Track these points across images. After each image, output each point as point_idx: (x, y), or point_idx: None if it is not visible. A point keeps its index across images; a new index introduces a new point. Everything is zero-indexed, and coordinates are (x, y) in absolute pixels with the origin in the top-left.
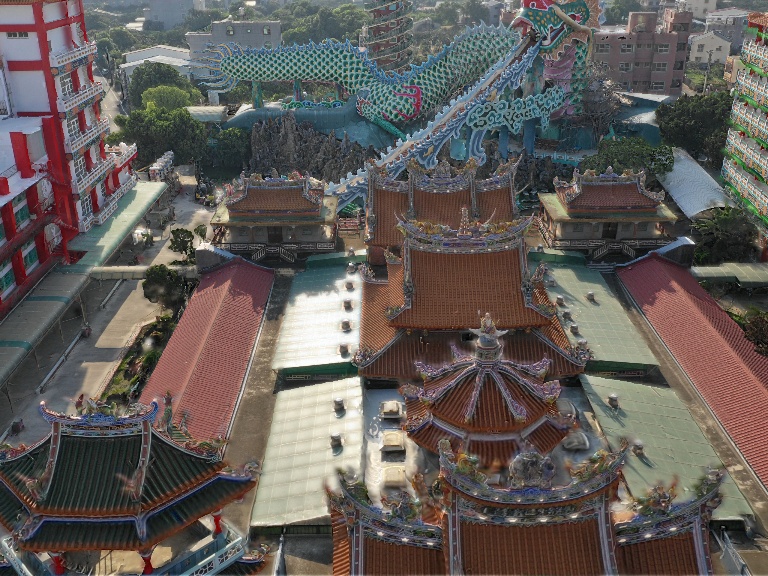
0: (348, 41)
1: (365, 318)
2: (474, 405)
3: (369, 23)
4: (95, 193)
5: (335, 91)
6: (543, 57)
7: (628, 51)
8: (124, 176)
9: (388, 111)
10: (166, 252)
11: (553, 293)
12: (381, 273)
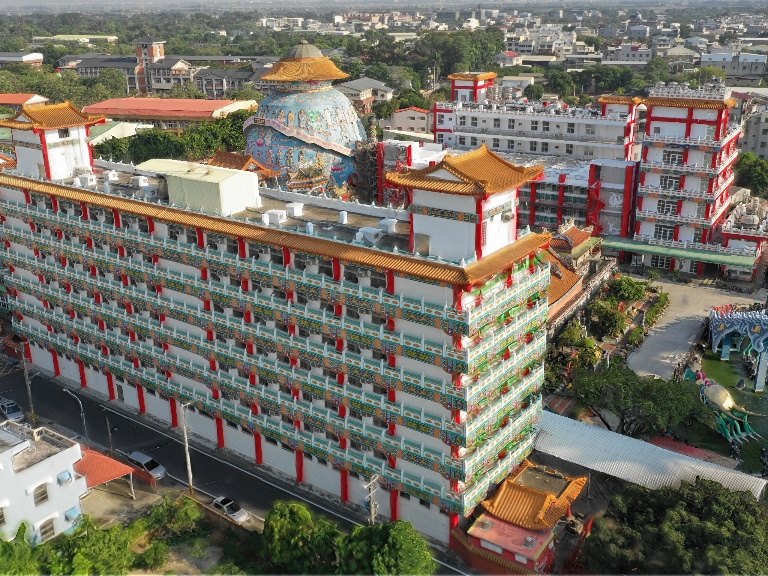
0: None
1: None
2: None
3: None
4: (676, 231)
5: None
6: None
7: None
8: (741, 245)
9: None
10: (661, 283)
11: None
12: None
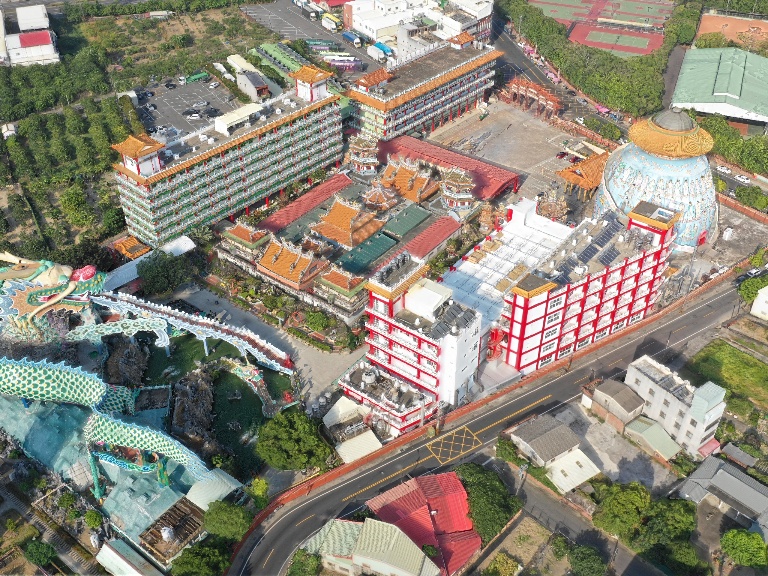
0: None
1: None
2: (388, 191)
3: None
4: None
5: None
6: None
7: None
8: None
9: None
10: None
11: (306, 230)
12: (332, 262)
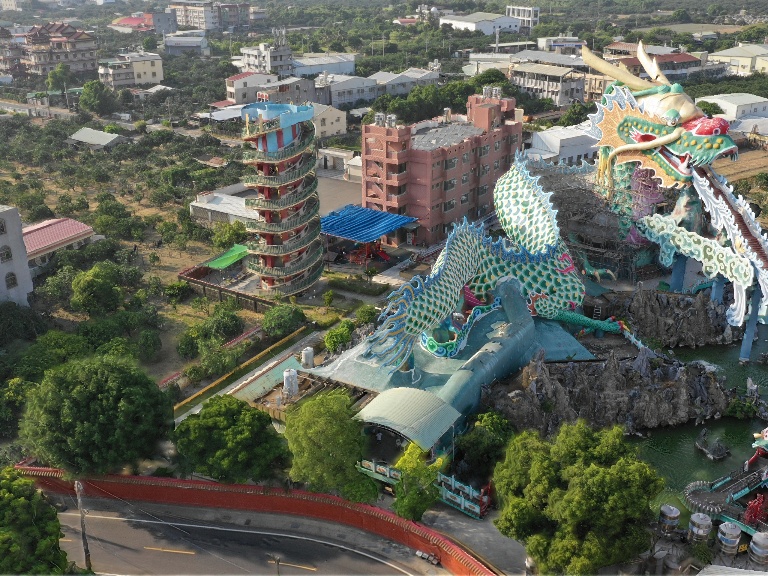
0: None
1: None
2: None
3: (282, 179)
4: None
5: (460, 295)
6: None
7: (498, 148)
8: None
9: (577, 298)
10: None
11: None
12: None
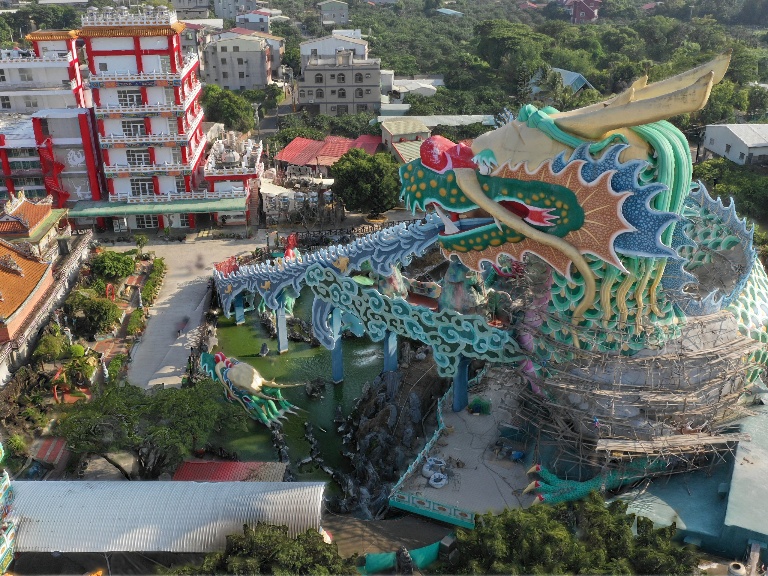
0: None
1: None
2: None
3: None
4: (156, 183)
5: None
6: (441, 251)
7: None
8: (228, 187)
9: None
10: (153, 247)
11: None
12: None
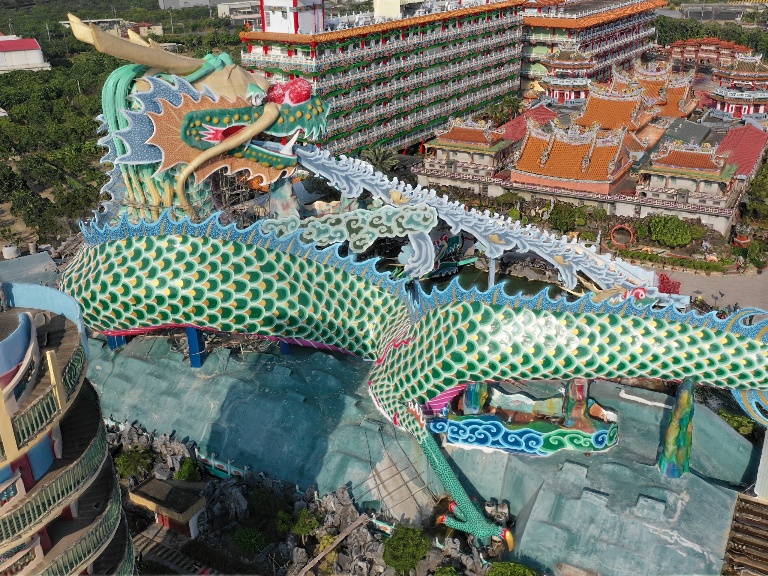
0: (455, 281)
1: (653, 142)
2: None
3: None
4: None
5: None
6: None
7: None
8: None
9: None
10: None
11: None
12: None
